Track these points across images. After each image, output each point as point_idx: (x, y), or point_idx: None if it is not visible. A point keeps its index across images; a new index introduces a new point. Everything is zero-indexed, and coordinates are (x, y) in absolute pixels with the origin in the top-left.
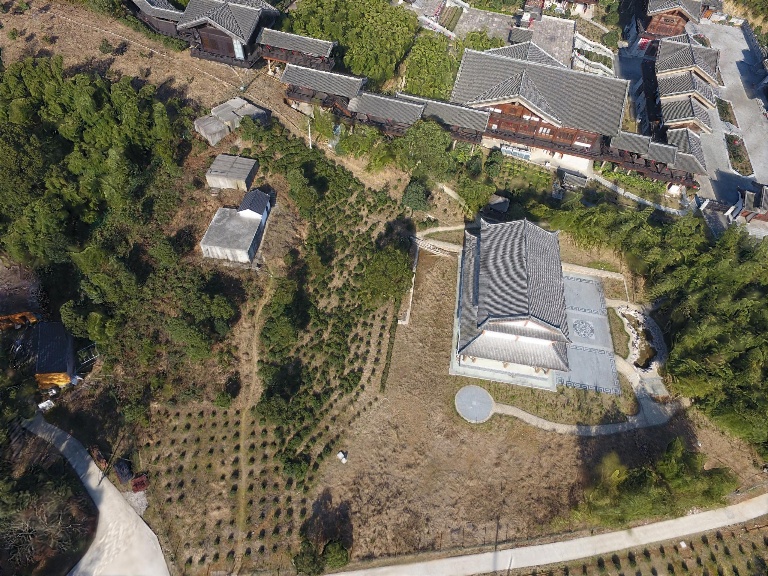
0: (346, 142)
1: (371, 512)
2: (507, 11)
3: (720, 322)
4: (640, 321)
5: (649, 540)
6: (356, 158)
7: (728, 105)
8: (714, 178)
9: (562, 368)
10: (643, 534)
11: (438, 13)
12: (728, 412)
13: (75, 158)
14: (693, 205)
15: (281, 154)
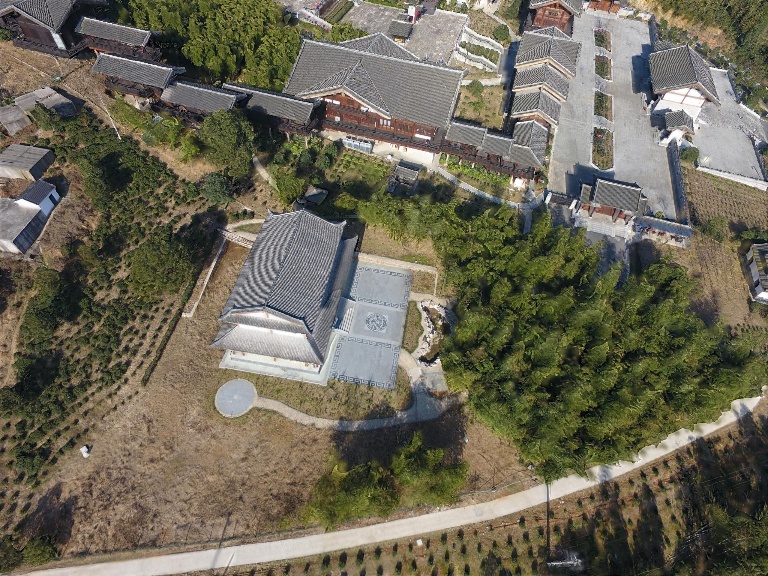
0: (150, 132)
1: (97, 507)
2: (400, 5)
3: (501, 315)
4: (442, 315)
5: (385, 538)
6: (172, 149)
7: (609, 99)
8: (571, 172)
9: (316, 361)
10: (380, 531)
11: (321, 6)
12: (480, 407)
13: None
14: (539, 199)
15: (84, 144)
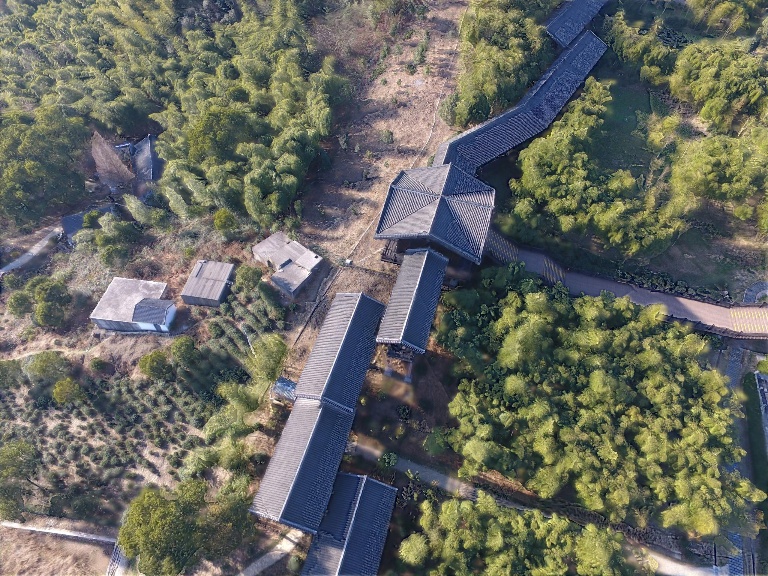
0: None
1: None
2: None
3: None
4: None
5: None
6: None
7: None
8: None
9: None
10: None
11: None
12: None
13: (224, 166)
14: None
15: None
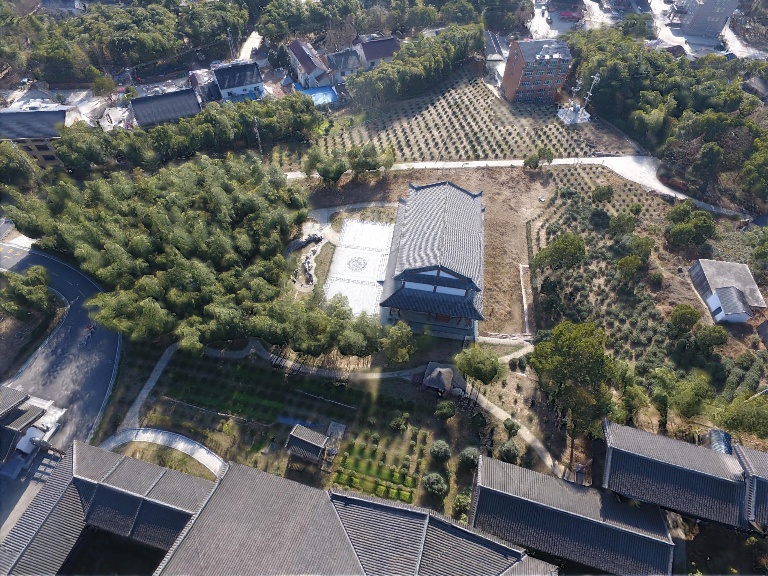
0: None
1: (516, 179)
2: None
3: (246, 231)
4: None
5: None
6: None
7: None
8: None
9: None
10: None
11: None
12: None
13: None
14: None
15: None
